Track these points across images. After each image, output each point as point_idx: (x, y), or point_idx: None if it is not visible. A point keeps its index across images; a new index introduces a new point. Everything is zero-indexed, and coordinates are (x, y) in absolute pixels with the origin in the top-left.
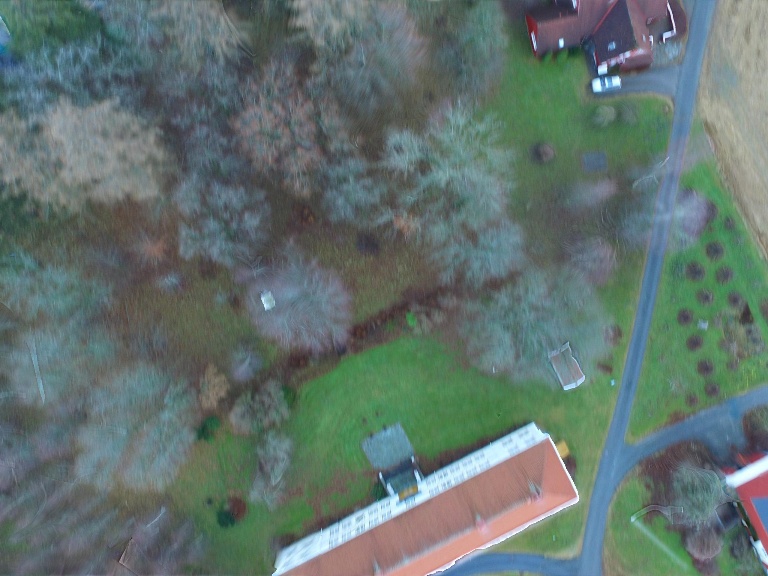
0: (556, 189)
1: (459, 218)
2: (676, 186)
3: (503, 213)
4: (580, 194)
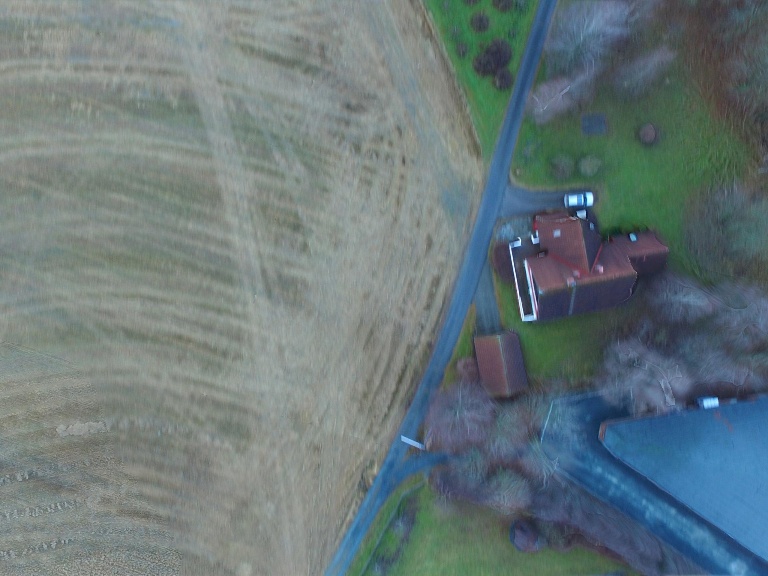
0: (636, 98)
1: (740, 73)
2: (514, 93)
3: (691, 78)
4: (613, 91)
